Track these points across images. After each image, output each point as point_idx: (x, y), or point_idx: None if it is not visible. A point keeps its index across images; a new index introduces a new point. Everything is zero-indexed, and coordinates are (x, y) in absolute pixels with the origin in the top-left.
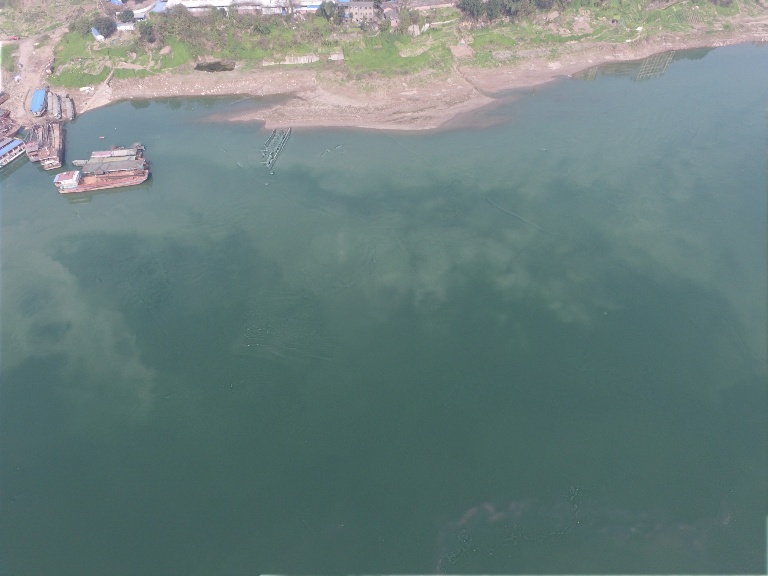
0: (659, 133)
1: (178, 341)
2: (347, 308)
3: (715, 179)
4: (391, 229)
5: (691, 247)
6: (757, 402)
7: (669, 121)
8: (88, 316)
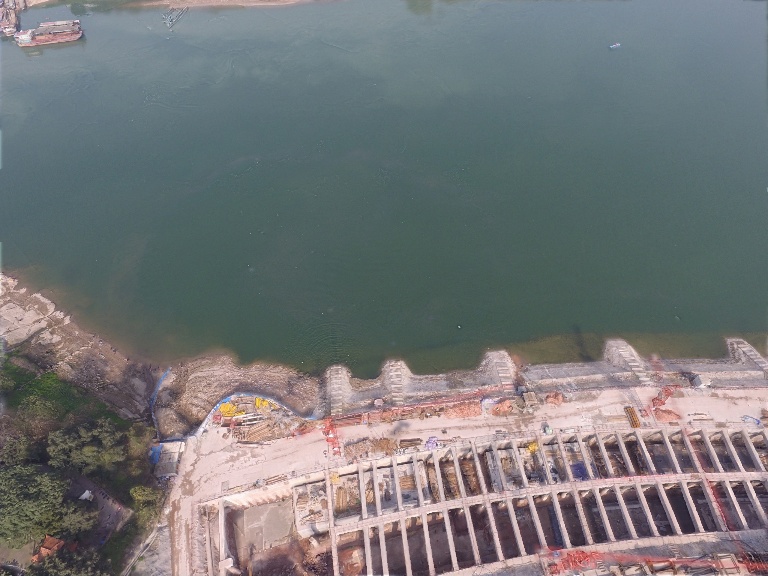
0: (452, 0)
1: (103, 108)
2: (213, 90)
3: (478, 23)
4: None
5: (444, 55)
6: (443, 110)
7: None
8: (44, 103)
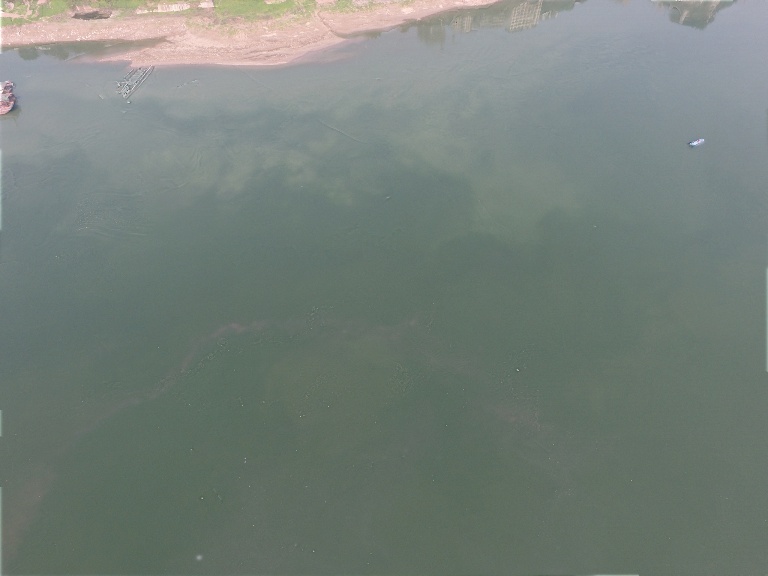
0: (481, 64)
1: (21, 230)
2: (172, 201)
3: (516, 98)
4: None
5: (477, 149)
6: (481, 250)
7: (493, 54)
8: None
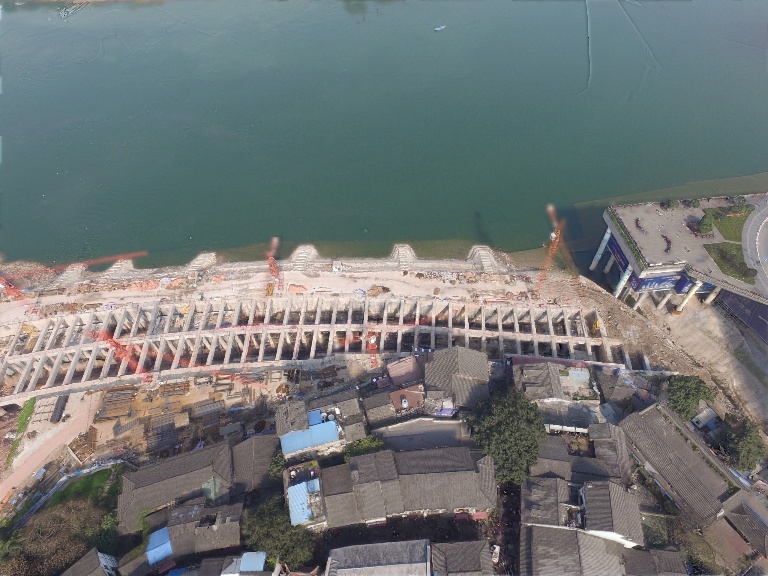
0: None
1: None
2: None
3: (337, 12)
4: (120, 36)
5: (293, 38)
6: None
7: None
8: None
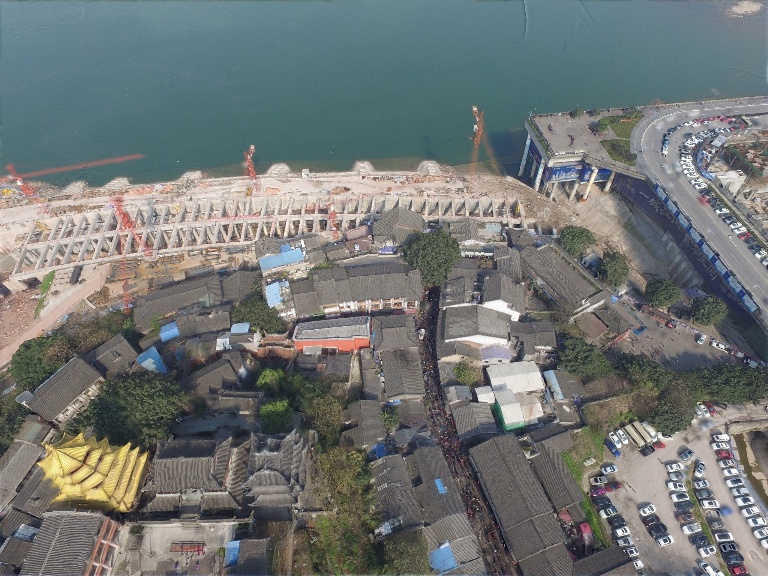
0: None
1: None
2: None
3: None
4: None
5: None
6: None
7: None
8: None
